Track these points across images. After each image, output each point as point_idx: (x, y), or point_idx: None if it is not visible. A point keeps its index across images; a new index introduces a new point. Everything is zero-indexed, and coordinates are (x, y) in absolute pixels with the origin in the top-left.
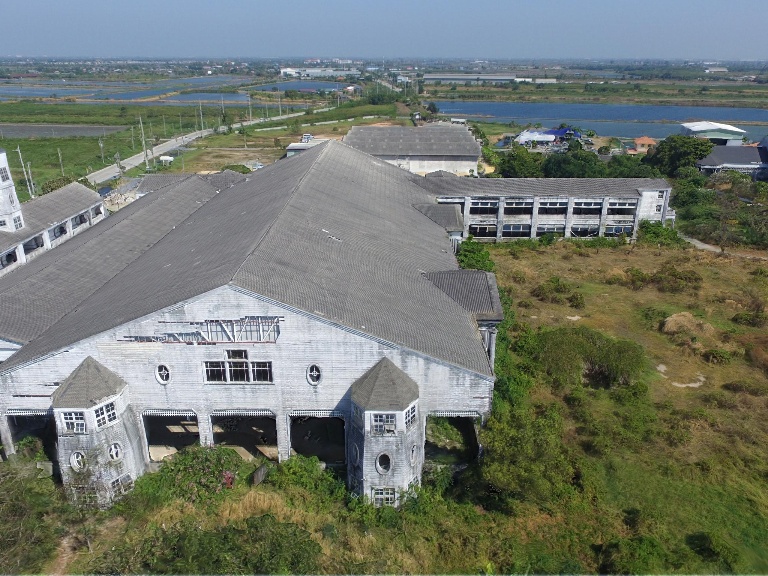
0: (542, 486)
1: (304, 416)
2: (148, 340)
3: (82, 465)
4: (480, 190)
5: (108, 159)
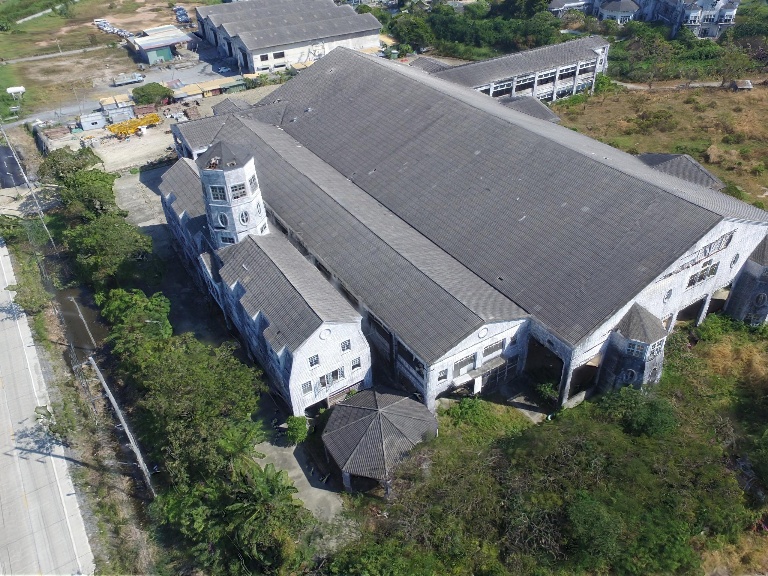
0: None
1: None
2: (669, 275)
3: None
4: (495, 74)
5: None
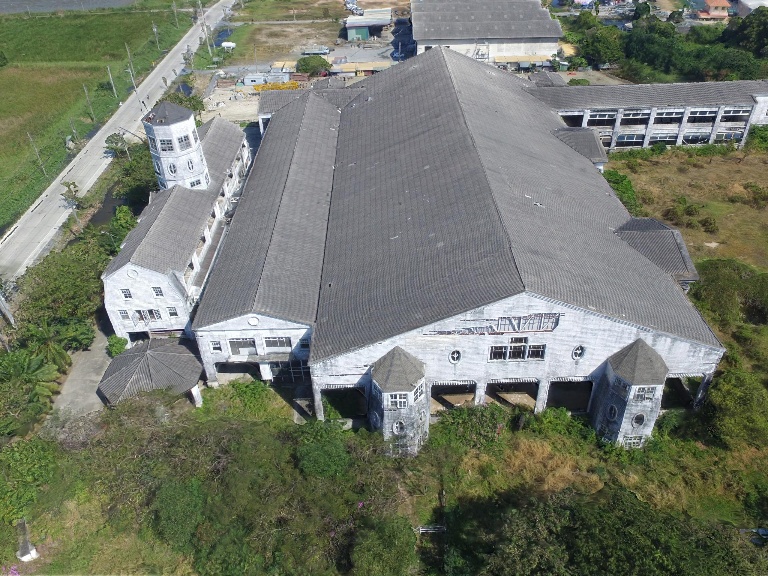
0: (767, 436)
1: (562, 381)
2: (448, 333)
3: (399, 429)
4: (598, 101)
5: (161, 44)
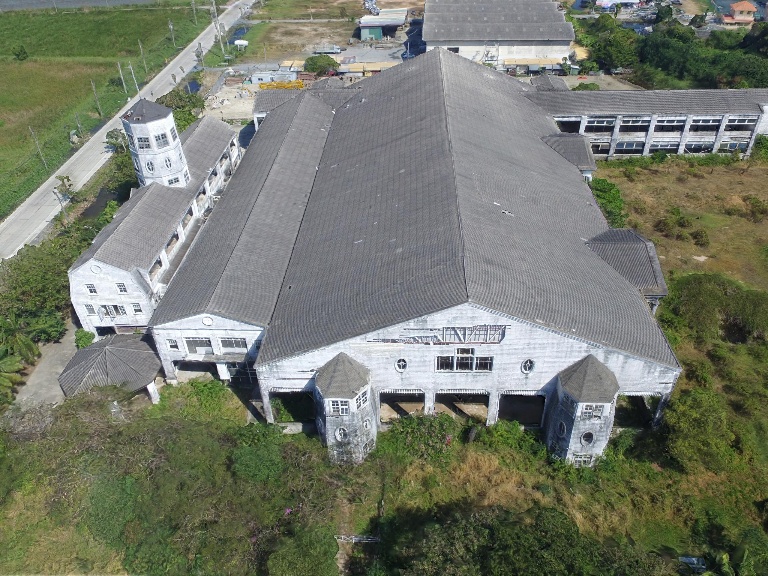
0: (721, 461)
1: (513, 394)
2: (392, 341)
3: (342, 436)
4: (596, 107)
5: (177, 40)
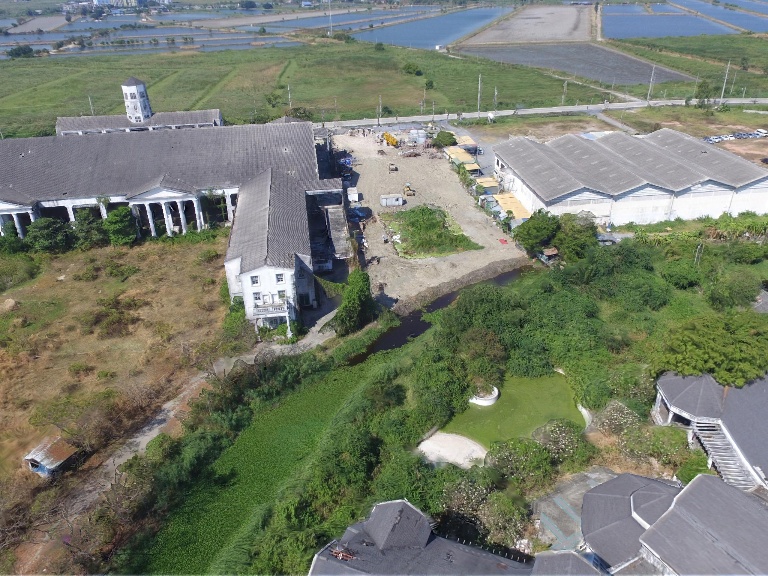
0: None
1: None
2: None
3: None
4: (248, 195)
5: (507, 106)
